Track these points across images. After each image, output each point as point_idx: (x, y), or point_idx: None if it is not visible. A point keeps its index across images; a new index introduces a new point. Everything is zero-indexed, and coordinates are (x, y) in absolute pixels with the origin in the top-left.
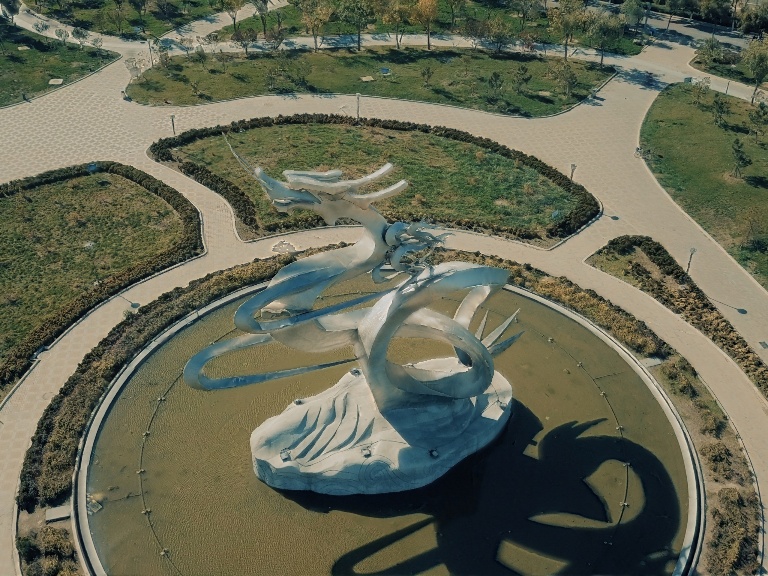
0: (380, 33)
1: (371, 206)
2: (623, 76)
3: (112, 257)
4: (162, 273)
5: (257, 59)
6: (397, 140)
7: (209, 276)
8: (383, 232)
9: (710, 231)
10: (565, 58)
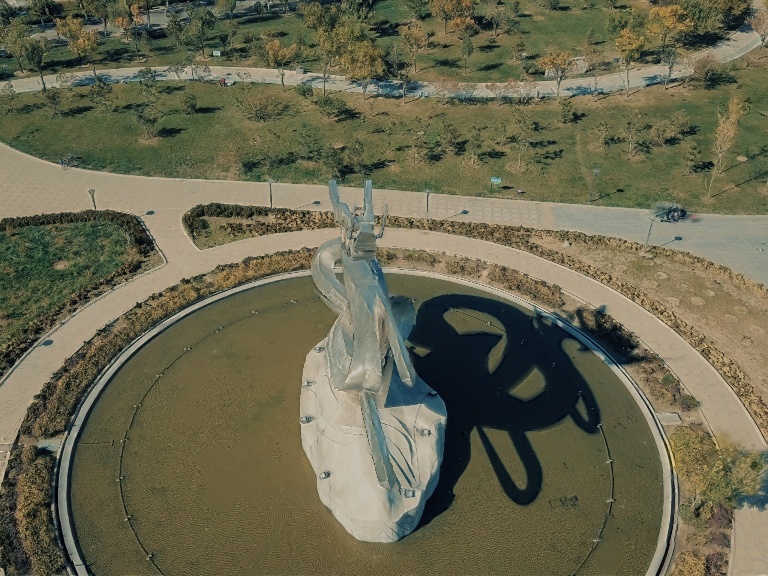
0: None
1: None
2: None
3: None
4: None
5: None
6: None
7: (5, 540)
8: None
9: (210, 178)
10: None
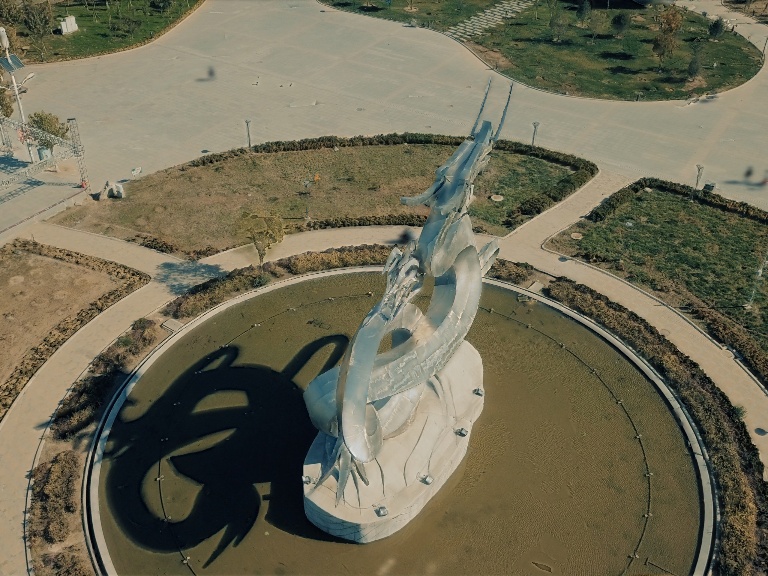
0: None
1: (435, 221)
2: None
3: None
4: None
5: None
6: None
7: (766, 499)
8: None
9: None
10: None
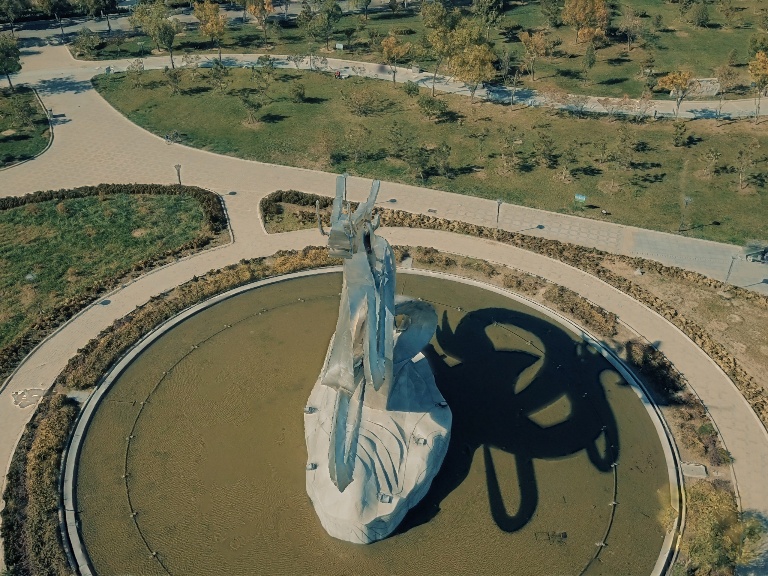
0: None
1: None
2: (43, 90)
3: None
4: None
5: None
6: None
7: (14, 475)
8: (365, 240)
9: (298, 166)
10: None
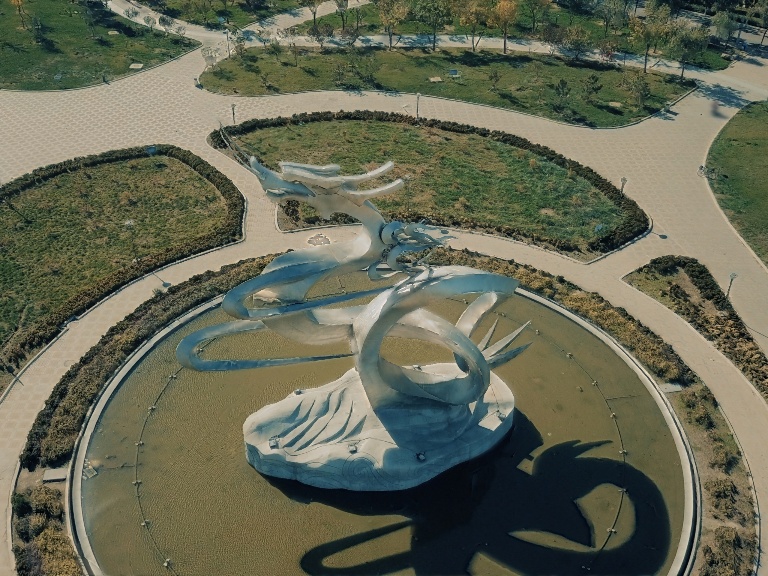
0: (458, 34)
1: (369, 203)
2: (703, 91)
3: (154, 237)
4: (198, 256)
5: (330, 54)
6: (453, 142)
7: (241, 262)
8: (380, 230)
9: (764, 258)
10: (644, 69)
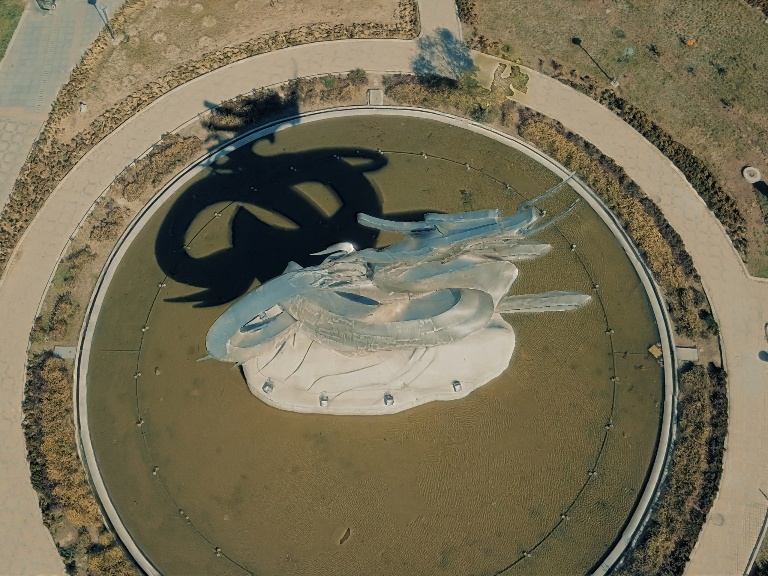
0: None
1: None
2: None
3: None
4: None
5: None
6: None
7: None
8: None
9: None
10: None
